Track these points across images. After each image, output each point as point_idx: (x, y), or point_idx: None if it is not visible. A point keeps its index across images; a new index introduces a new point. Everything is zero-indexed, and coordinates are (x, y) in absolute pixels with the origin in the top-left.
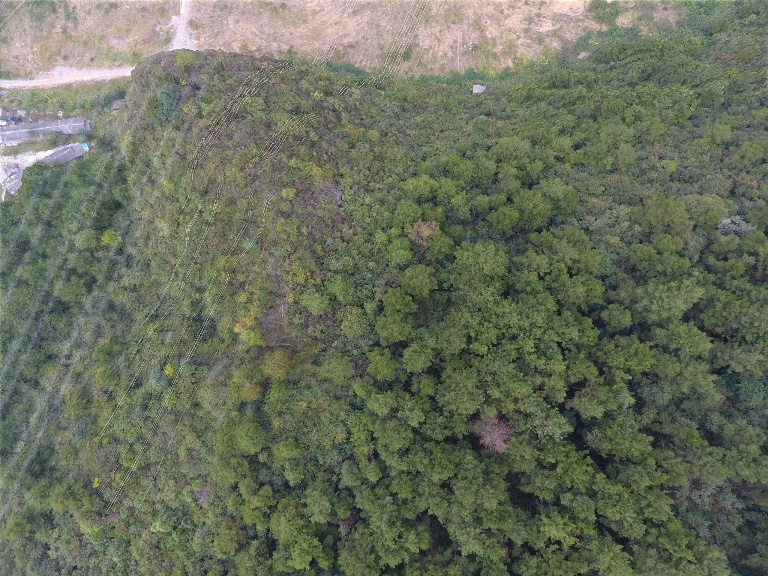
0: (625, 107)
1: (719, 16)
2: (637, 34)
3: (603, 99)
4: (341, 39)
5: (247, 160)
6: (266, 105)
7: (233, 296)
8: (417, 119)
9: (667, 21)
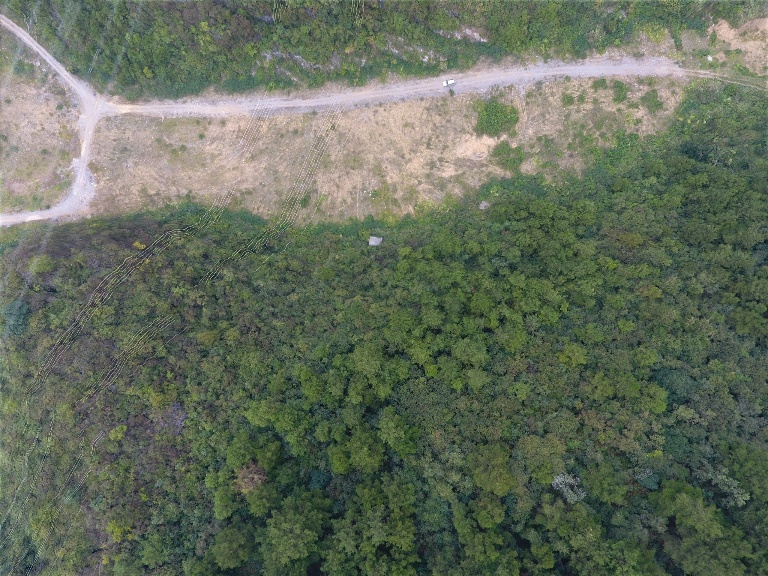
0: (492, 307)
1: (624, 169)
2: (540, 183)
3: (474, 292)
4: (239, 185)
5: (81, 392)
6: (116, 316)
7: (54, 547)
8: (292, 298)
9: (572, 169)
